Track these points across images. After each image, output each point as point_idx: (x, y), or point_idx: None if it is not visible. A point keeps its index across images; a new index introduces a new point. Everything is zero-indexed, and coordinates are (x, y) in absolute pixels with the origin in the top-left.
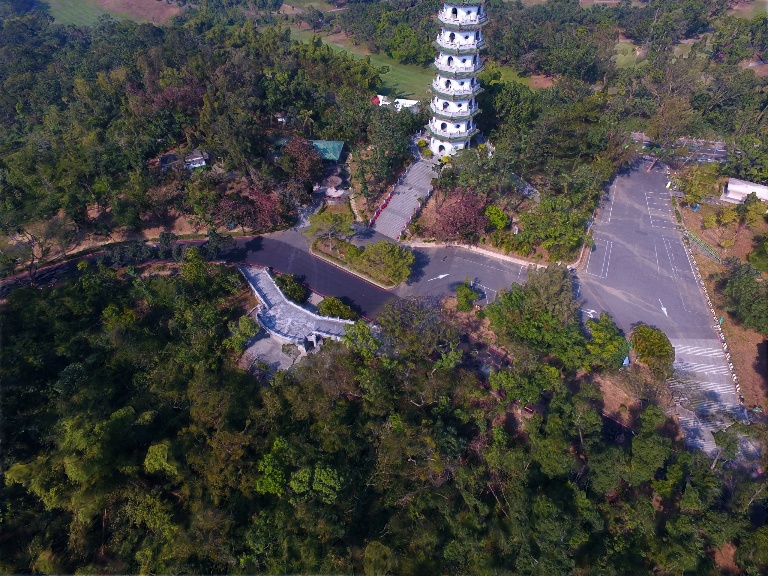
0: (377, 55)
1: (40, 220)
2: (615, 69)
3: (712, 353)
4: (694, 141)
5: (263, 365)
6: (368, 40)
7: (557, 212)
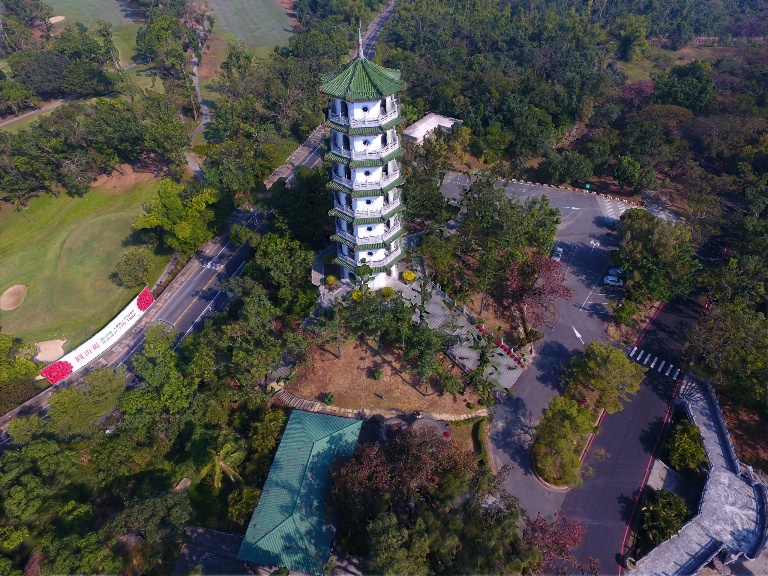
0: None
1: None
2: (147, 126)
3: (608, 202)
4: (317, 132)
5: None
6: None
7: None
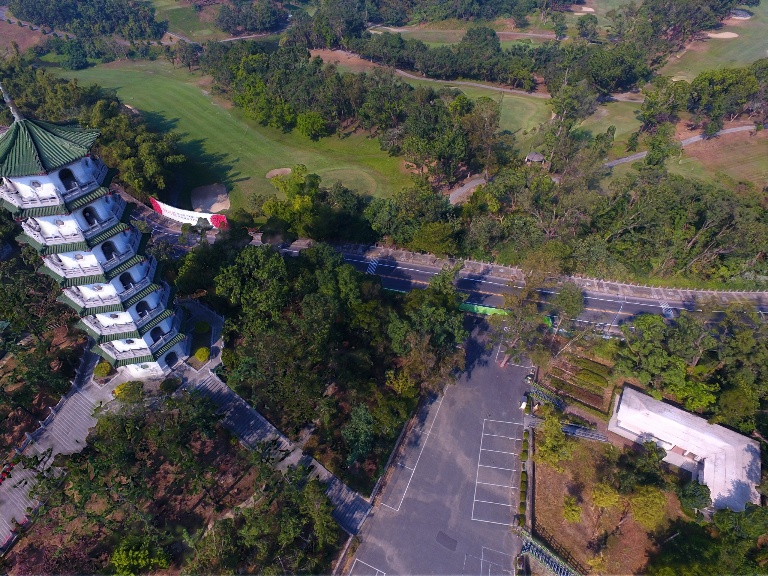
0: (239, 109)
1: None
2: (513, 148)
3: None
4: (594, 284)
5: None
6: (226, 91)
7: (248, 560)
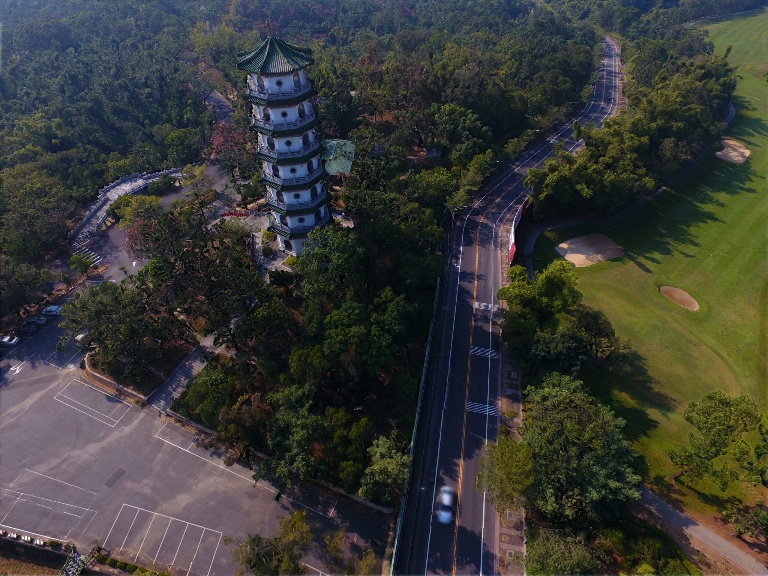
0: None
1: (218, 74)
2: None
3: None
4: None
5: (69, 171)
6: None
7: None
